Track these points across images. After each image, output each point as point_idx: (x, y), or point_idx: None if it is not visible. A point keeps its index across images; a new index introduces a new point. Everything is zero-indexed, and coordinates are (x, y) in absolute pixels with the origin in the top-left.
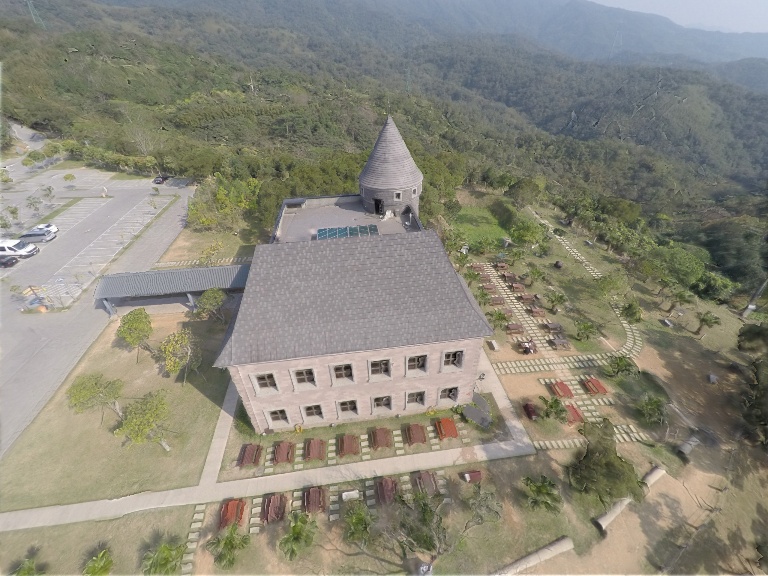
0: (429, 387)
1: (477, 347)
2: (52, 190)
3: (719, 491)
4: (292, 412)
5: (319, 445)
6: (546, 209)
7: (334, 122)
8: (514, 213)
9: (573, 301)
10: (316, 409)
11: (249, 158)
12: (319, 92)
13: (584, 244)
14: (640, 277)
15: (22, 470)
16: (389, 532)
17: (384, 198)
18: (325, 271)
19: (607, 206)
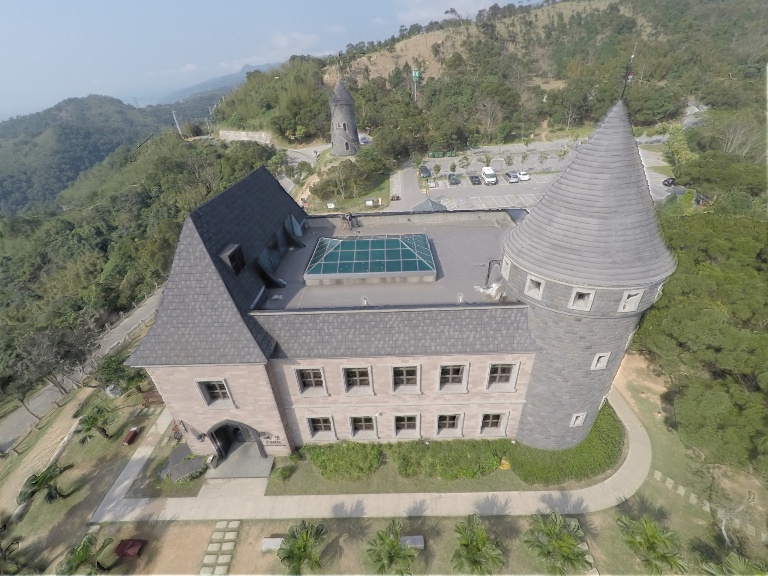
0: None
1: None
2: (567, 153)
3: None
4: None
5: None
6: None
7: None
8: None
9: None
10: None
11: None
12: None
13: None
14: None
15: None
16: None
17: None
18: None
19: None
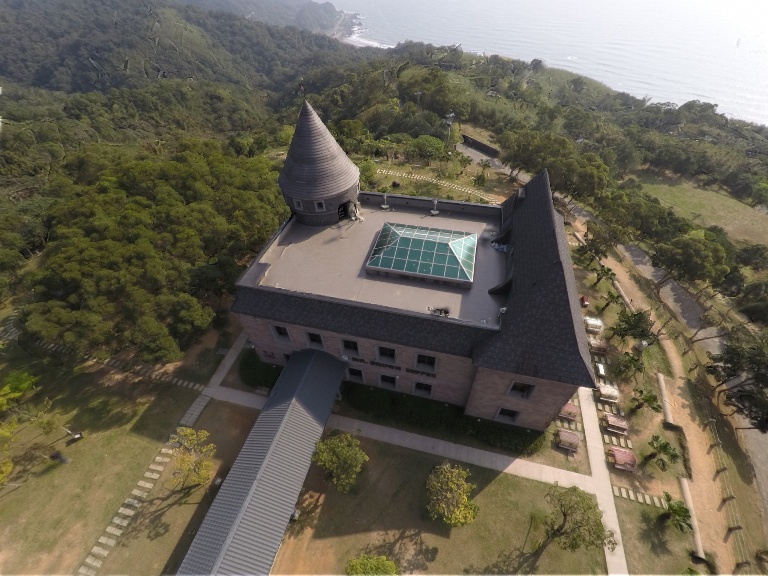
0: None
1: None
2: None
3: (585, 224)
4: None
5: None
6: None
7: None
8: None
9: None
10: None
11: None
12: None
13: None
14: (423, 165)
15: None
16: None
17: (351, 197)
18: None
19: (344, 130)
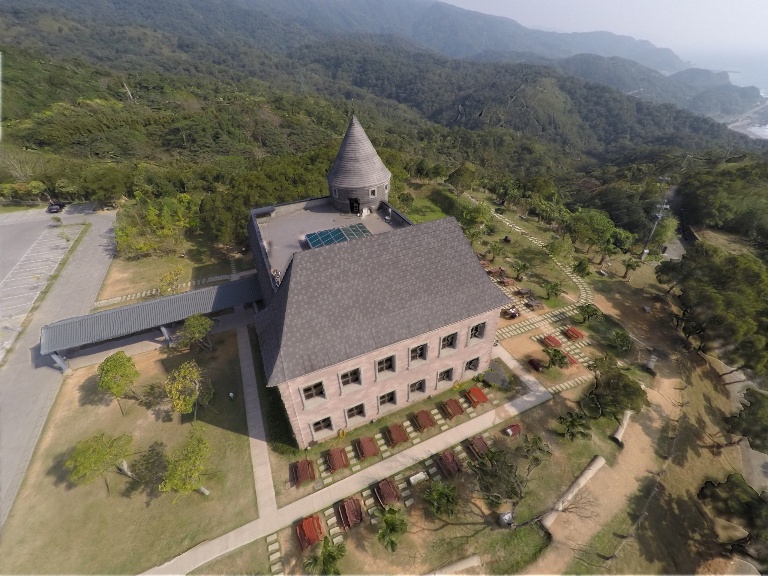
0: (456, 362)
1: (496, 316)
2: None
3: (682, 390)
4: (336, 417)
5: (369, 442)
6: (478, 193)
7: (237, 128)
8: (454, 199)
9: None
10: (357, 409)
11: (167, 172)
12: (210, 97)
13: (519, 219)
14: None
15: (23, 572)
16: (462, 499)
17: (360, 196)
18: (363, 269)
19: (527, 184)
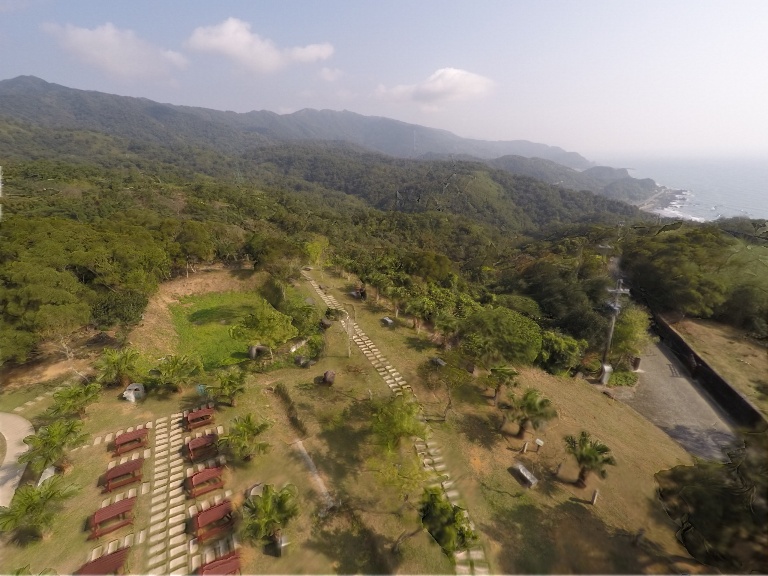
0: None
1: None
2: None
3: None
4: None
5: None
6: (337, 280)
7: None
8: None
9: (341, 475)
10: None
11: None
12: (113, 186)
13: (381, 324)
14: None
15: None
16: None
17: None
18: None
19: (410, 264)
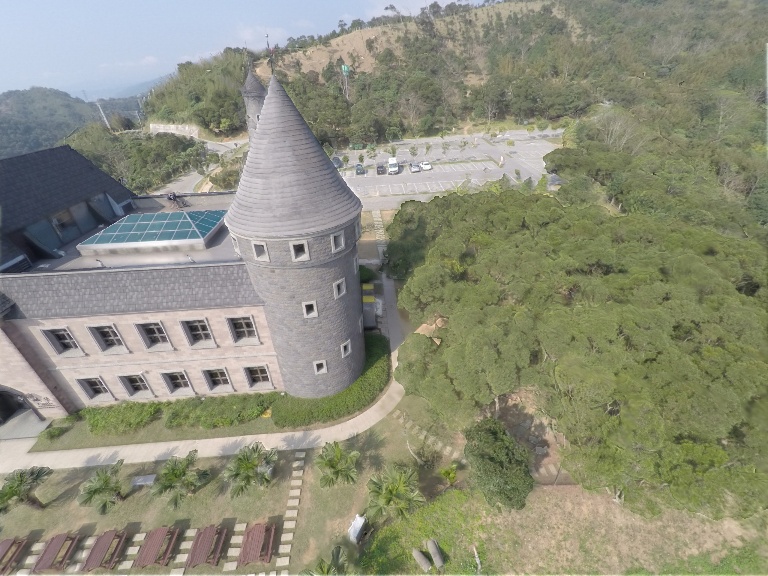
0: None
1: None
2: (467, 144)
3: None
4: None
5: None
6: None
7: None
8: None
9: None
10: None
11: (643, 181)
12: None
13: None
14: None
15: None
16: None
17: None
18: None
19: None
